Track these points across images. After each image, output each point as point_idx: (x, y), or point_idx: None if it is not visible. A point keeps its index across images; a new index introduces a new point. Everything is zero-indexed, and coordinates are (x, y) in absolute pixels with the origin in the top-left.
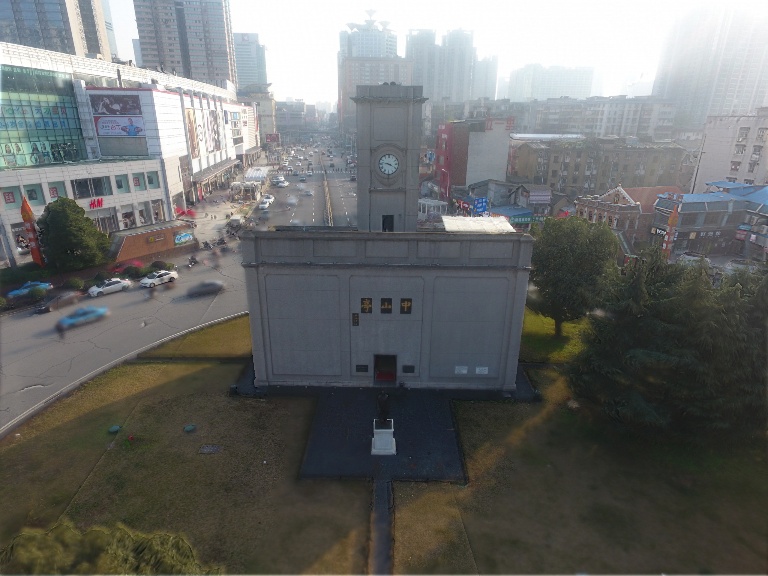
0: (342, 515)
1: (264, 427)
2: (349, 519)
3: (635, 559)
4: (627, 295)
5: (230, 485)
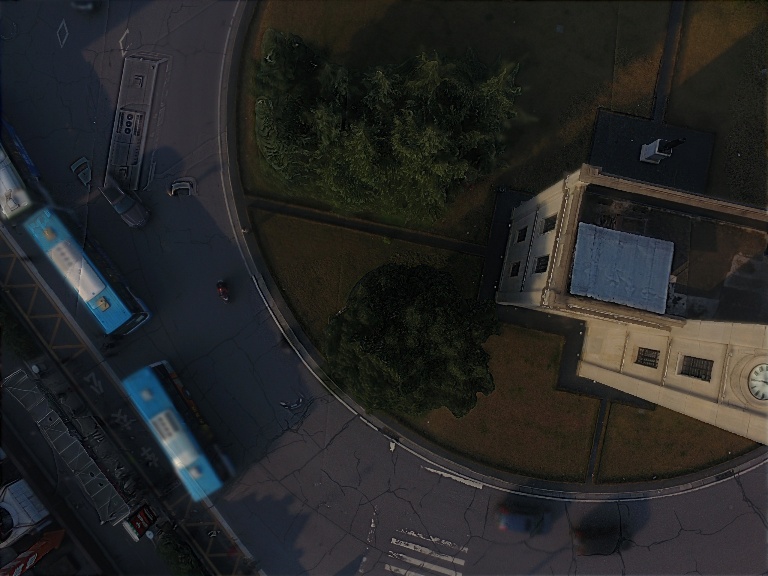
0: (687, 98)
1: (743, 195)
2: (683, 94)
3: (523, 33)
4: (508, 83)
5: (762, 135)
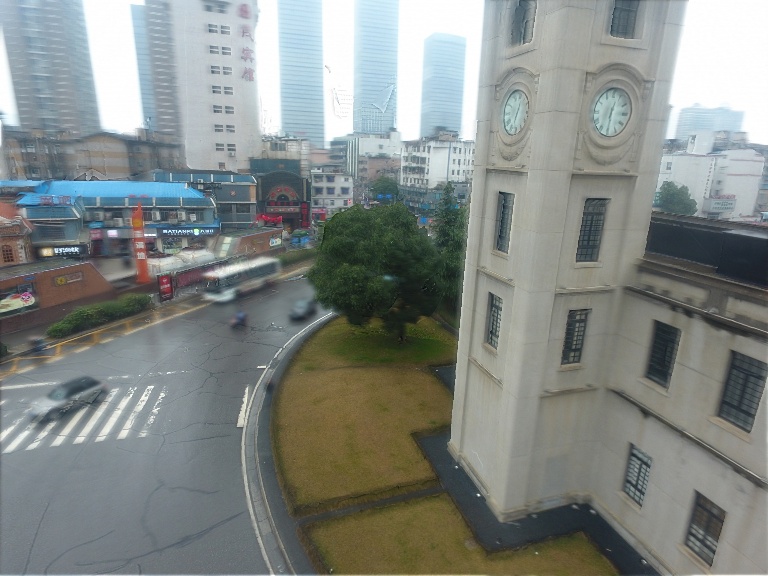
0: None
1: None
2: None
3: None
4: None
5: None
